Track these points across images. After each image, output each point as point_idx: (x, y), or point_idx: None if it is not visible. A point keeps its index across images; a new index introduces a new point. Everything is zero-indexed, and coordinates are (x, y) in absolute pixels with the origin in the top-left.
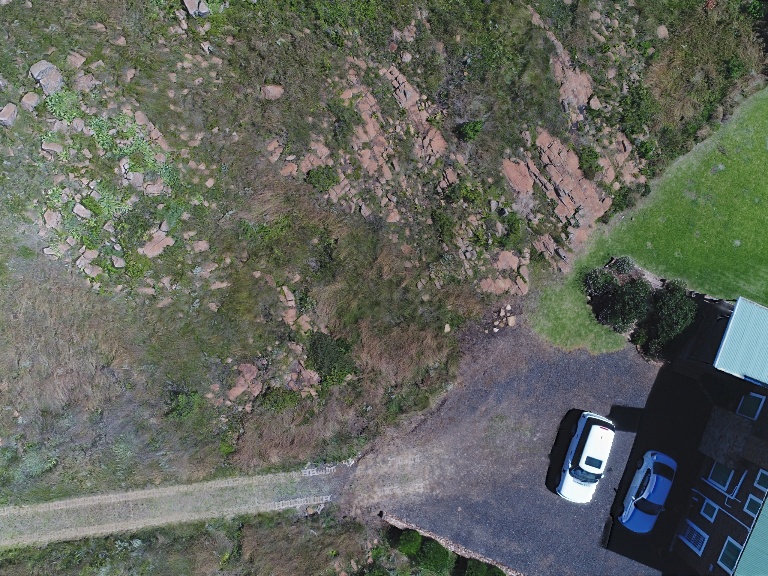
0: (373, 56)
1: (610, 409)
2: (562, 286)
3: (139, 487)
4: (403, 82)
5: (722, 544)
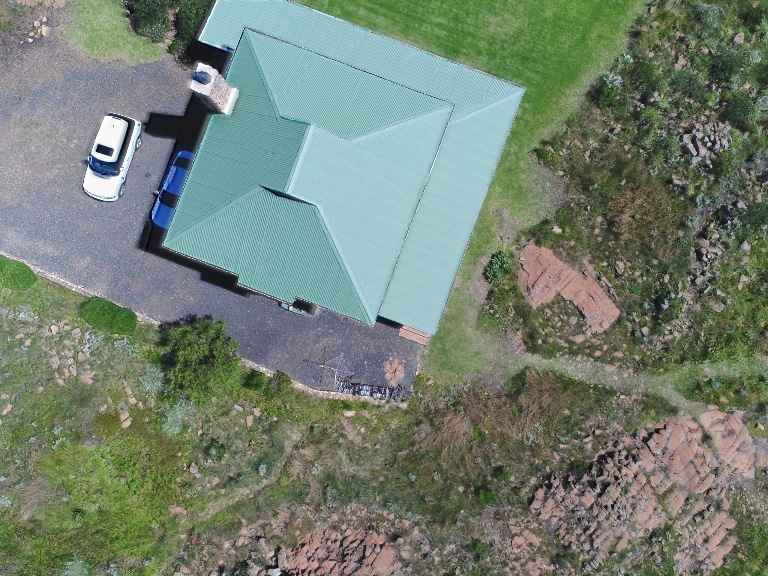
0: None
1: (149, 117)
2: (101, 1)
3: None
4: None
5: None
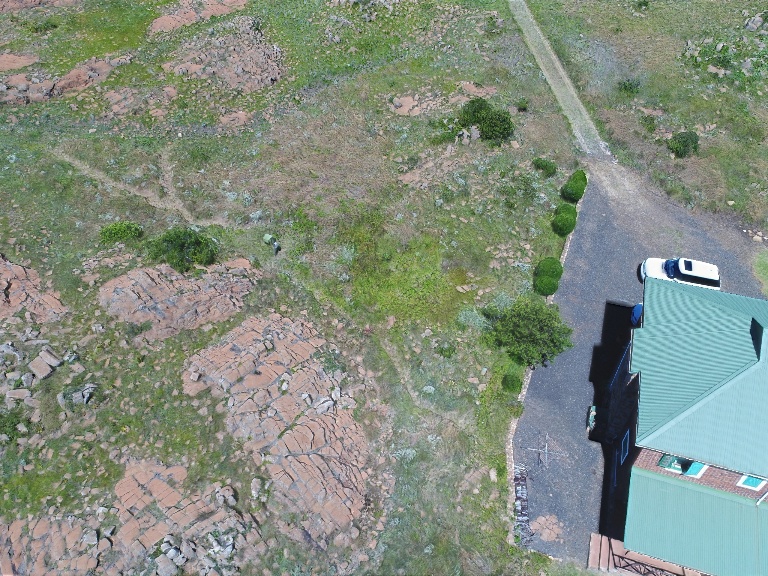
0: None
1: None
2: None
3: (571, 81)
4: None
5: None
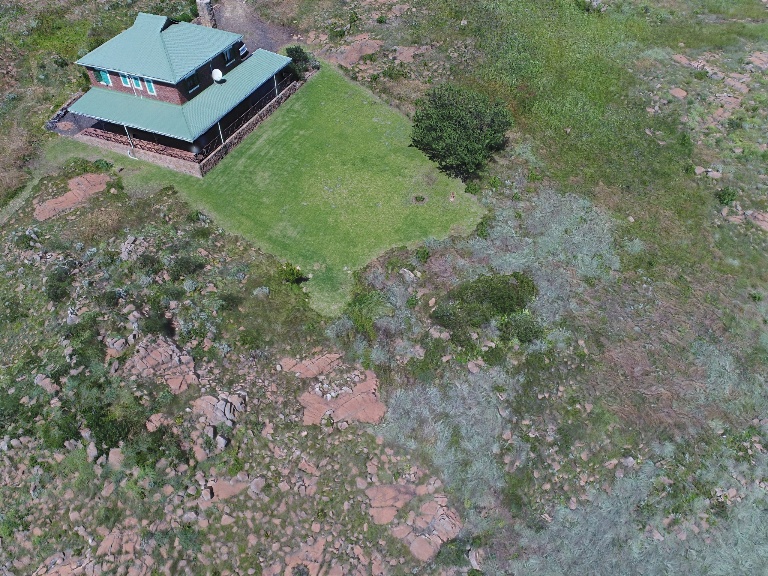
0: (414, 2)
1: None
2: None
3: None
4: (403, 7)
5: None
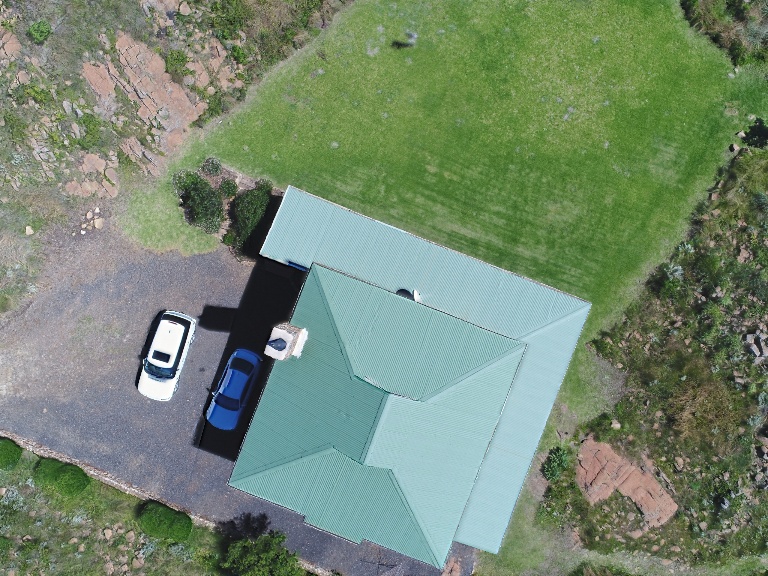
0: None
1: (203, 310)
2: (154, 189)
3: None
4: None
5: None
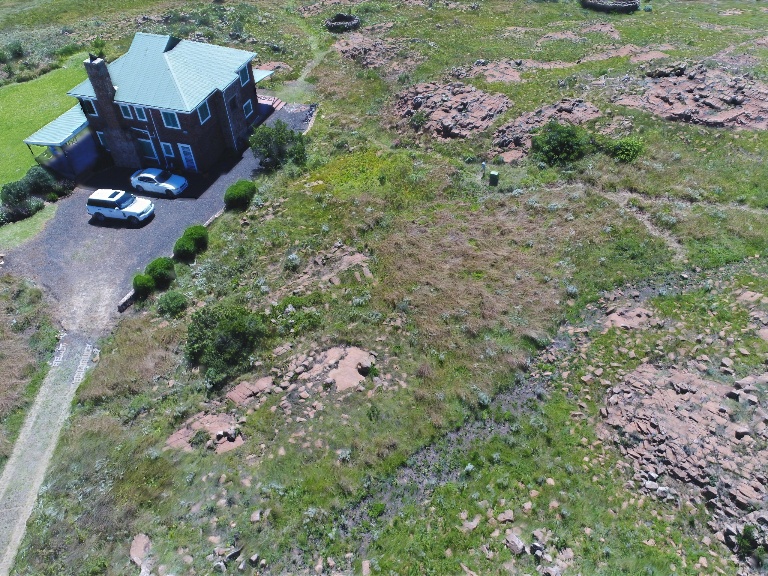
0: None
1: None
2: None
3: None
4: None
5: (171, 130)
